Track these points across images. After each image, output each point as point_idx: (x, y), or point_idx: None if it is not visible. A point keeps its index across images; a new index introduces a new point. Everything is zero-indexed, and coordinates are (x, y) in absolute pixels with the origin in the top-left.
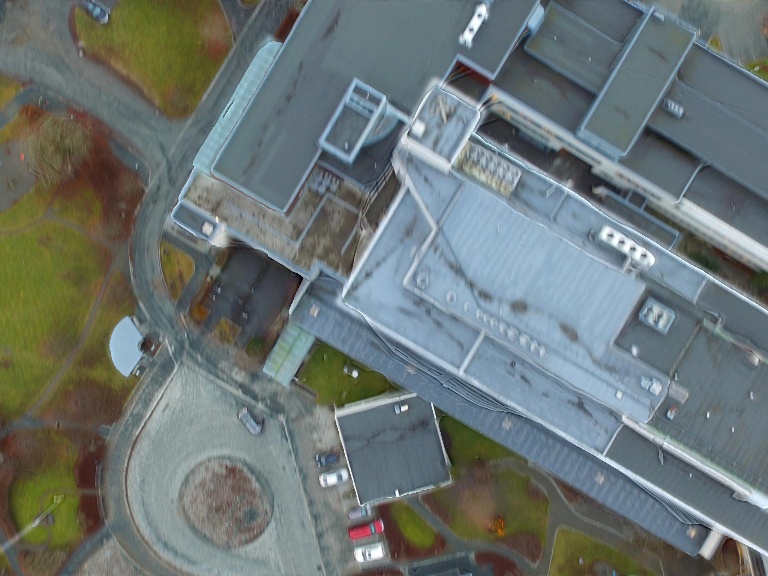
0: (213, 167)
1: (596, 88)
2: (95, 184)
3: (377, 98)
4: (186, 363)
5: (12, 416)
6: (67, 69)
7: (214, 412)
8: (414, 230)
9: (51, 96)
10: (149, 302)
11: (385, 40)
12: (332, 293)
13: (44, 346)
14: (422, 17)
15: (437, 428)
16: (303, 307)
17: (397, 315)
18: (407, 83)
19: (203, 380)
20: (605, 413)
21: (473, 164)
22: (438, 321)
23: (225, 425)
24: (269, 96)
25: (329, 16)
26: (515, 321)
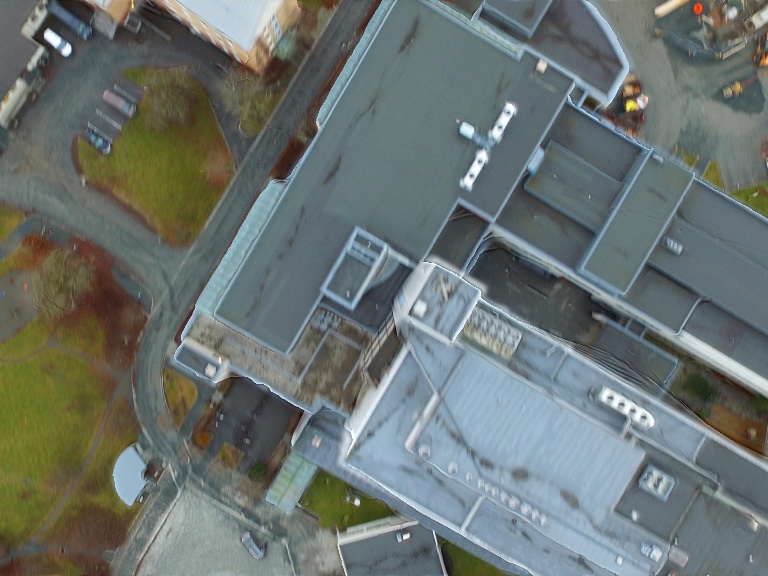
0: (216, 311)
1: (596, 227)
2: (98, 312)
3: (378, 246)
4: (189, 488)
5: (16, 542)
6: (70, 198)
7: (217, 536)
8: (416, 391)
9: (54, 225)
10: (152, 428)
11: (386, 185)
12: (334, 422)
13: (48, 473)
14: (423, 162)
15: (439, 555)
16: (305, 437)
17: (399, 474)
18: (408, 226)
19: (206, 504)
20: (606, 570)
21: (474, 328)
22: (440, 480)
23: (228, 548)
24: (271, 240)
25: (330, 161)
26: (516, 489)
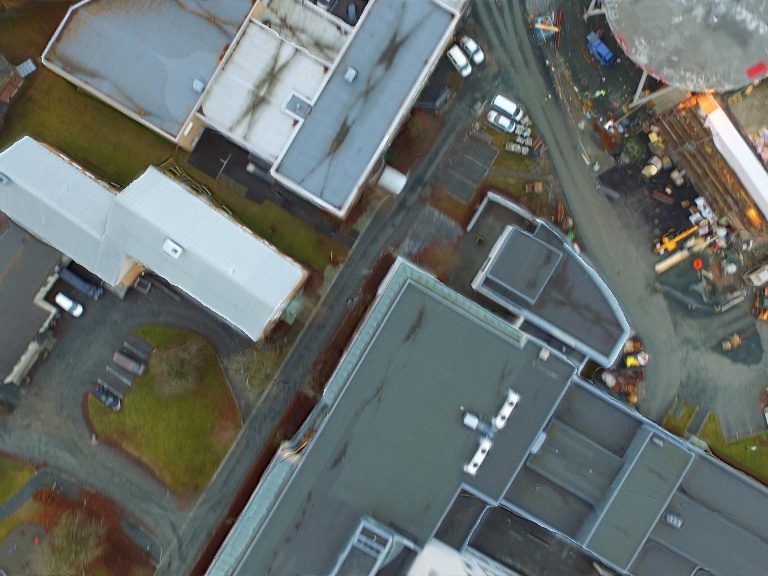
0: None
1: (597, 504)
2: (108, 564)
3: (384, 538)
4: None
5: None
6: (80, 453)
7: None
8: None
9: (65, 478)
10: None
11: (391, 471)
12: None
13: None
14: (427, 448)
15: None
16: None
17: None
18: (413, 510)
19: None
20: None
21: None
22: None
23: None
24: (278, 525)
25: (337, 448)
26: None
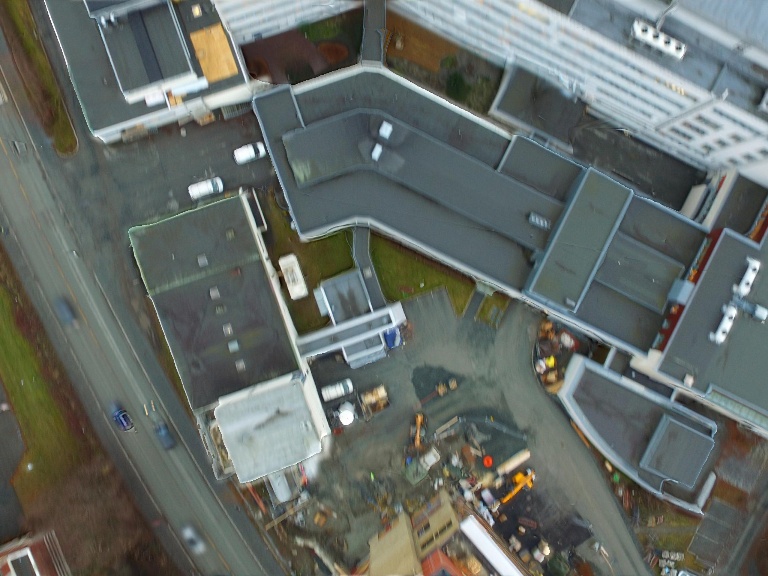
0: None
1: None
2: None
3: None
4: None
5: None
6: None
7: None
8: None
9: None
10: None
11: None
12: None
13: None
14: None
15: None
16: None
17: None
18: None
19: None
20: None
21: None
22: None
23: None
24: None
25: None
26: None
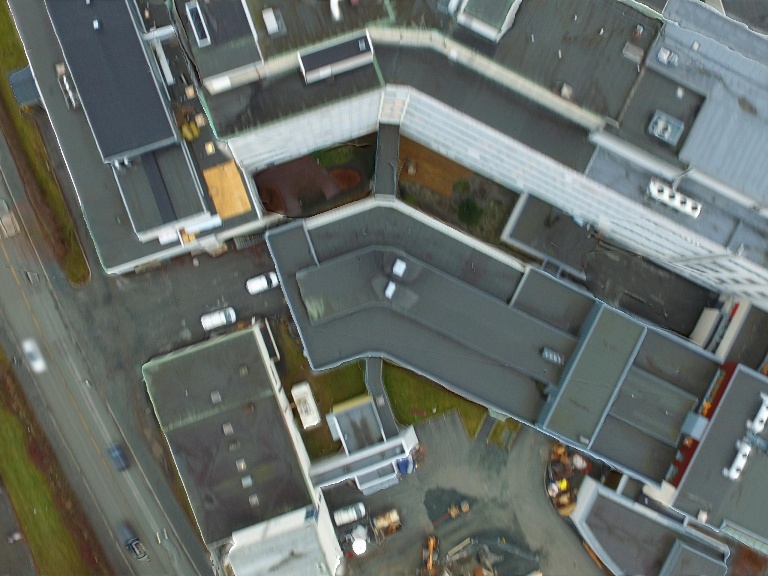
0: None
1: None
2: None
3: None
4: None
5: None
6: None
7: None
8: None
9: None
10: None
11: None
12: None
13: None
14: None
15: None
16: None
17: None
18: None
19: None
20: None
21: None
22: None
23: None
24: None
25: None
26: None
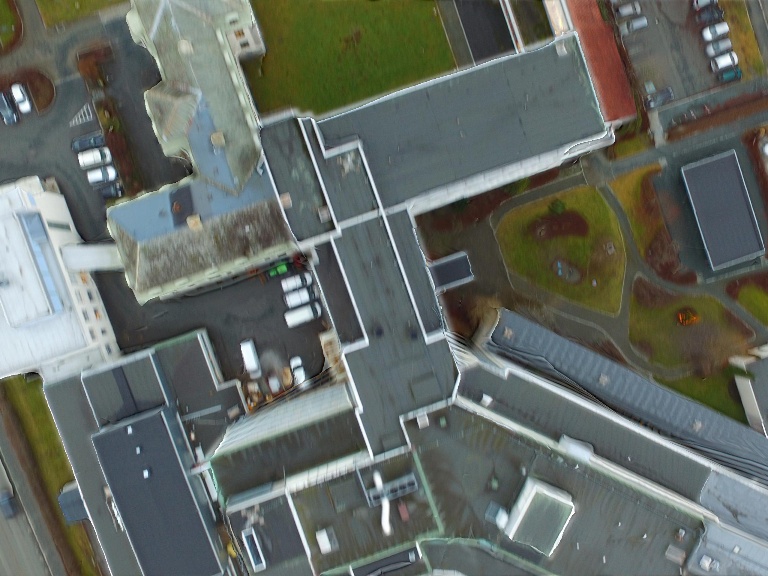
0: None
1: None
2: None
3: None
4: None
5: None
6: None
7: None
8: None
9: None
10: None
11: None
12: None
13: None
14: None
15: (761, 414)
16: None
17: None
18: None
19: None
20: (717, 512)
21: None
22: None
23: None
24: None
25: None
26: None
